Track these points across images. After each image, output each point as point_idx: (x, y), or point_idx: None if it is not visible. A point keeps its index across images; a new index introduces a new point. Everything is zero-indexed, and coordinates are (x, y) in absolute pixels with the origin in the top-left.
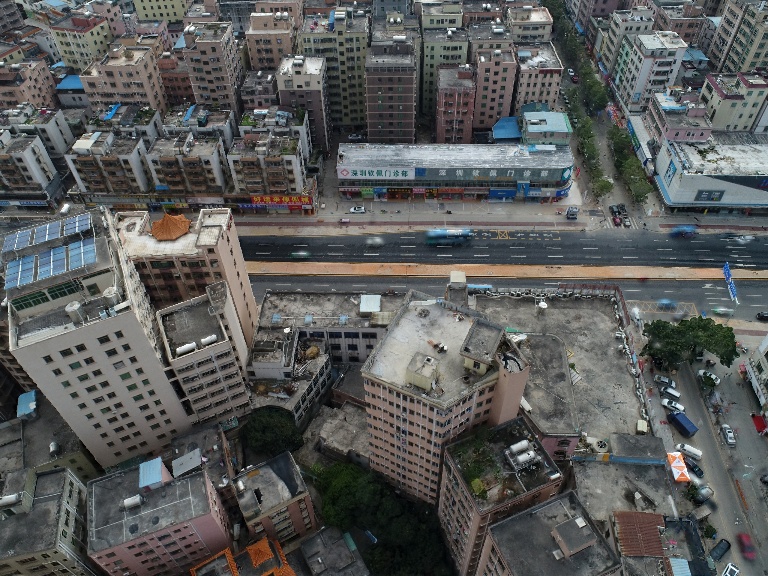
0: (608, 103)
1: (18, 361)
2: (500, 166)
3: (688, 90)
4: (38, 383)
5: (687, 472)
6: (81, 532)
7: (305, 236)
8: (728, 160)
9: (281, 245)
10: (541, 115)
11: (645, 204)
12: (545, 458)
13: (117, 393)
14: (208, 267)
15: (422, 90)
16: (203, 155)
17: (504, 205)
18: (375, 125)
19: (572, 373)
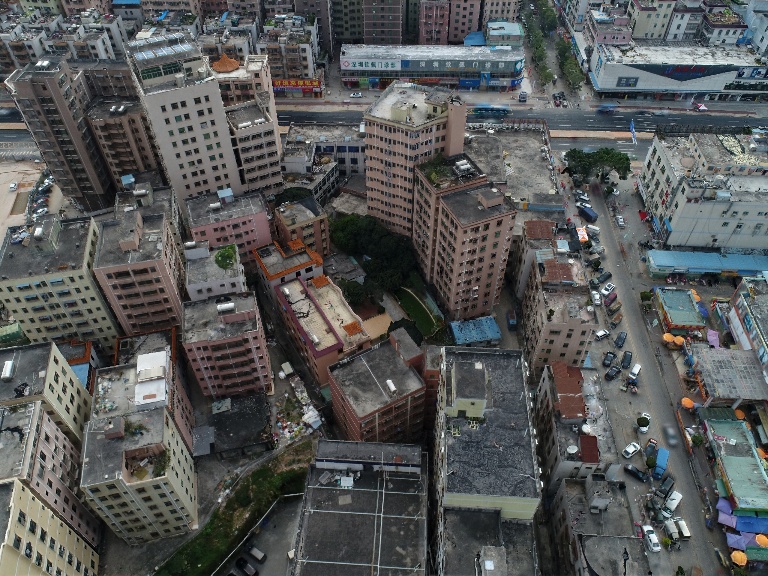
0: (560, 28)
1: (146, 106)
2: (467, 59)
3: (616, 6)
4: (155, 128)
5: (587, 237)
6: (181, 229)
7: (315, 111)
8: (642, 56)
9: (297, 116)
10: (501, 24)
11: (580, 93)
12: (478, 171)
13: (200, 150)
14: (254, 90)
15: (408, 11)
16: (237, 43)
17: (471, 93)
18: (370, 33)
19: (508, 168)
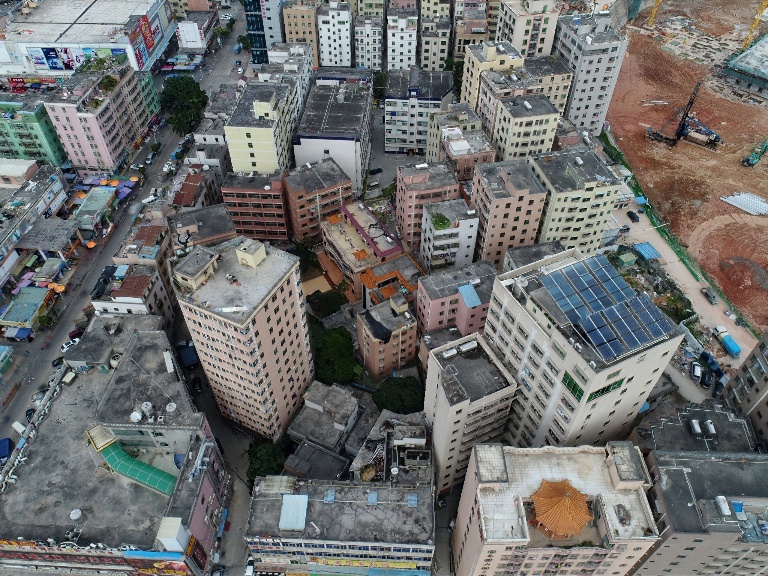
0: None
1: None
2: None
3: None
4: None
5: None
6: None
7: None
8: None
9: None
10: None
11: None
12: None
13: None
14: None
15: None
16: None
17: None
18: None
19: None
